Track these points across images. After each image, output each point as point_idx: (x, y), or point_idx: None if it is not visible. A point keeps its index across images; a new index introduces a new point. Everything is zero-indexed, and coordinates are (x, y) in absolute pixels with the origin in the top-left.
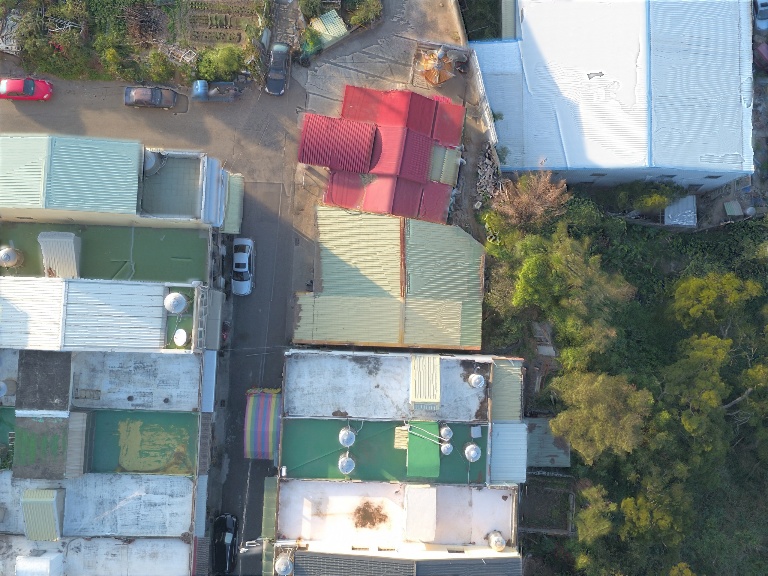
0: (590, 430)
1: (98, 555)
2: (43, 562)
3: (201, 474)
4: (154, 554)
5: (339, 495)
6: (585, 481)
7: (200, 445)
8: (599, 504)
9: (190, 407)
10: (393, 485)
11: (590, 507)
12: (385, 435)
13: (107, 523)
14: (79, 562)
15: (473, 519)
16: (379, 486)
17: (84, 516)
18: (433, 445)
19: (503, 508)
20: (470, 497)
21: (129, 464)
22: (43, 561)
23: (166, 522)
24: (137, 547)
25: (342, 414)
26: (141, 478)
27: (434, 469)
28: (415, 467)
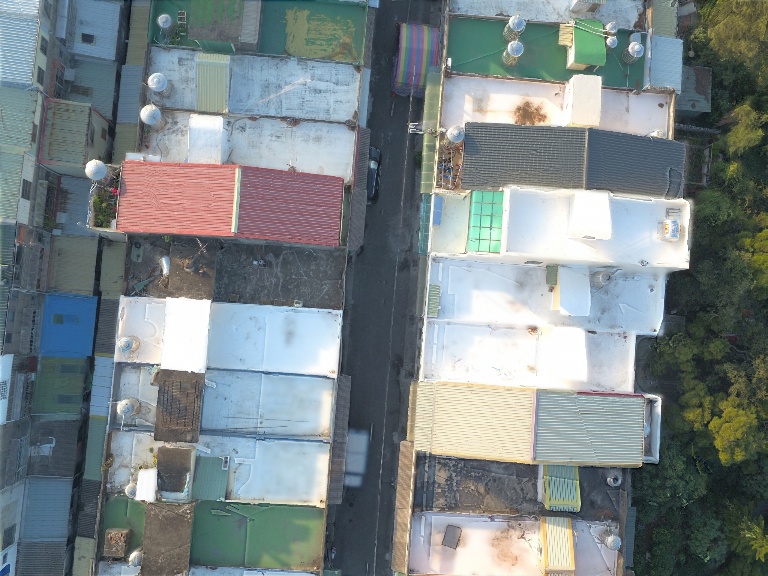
0: (753, 27)
1: (262, 136)
2: (216, 121)
3: (365, 67)
4: (318, 139)
5: (500, 93)
6: (731, 112)
7: (365, 37)
8: (752, 117)
9: (356, 0)
10: (553, 87)
11: (742, 121)
12: (546, 39)
13: (272, 106)
14: (243, 142)
15: (630, 124)
16: (539, 87)
17: (250, 98)
18: (599, 38)
19: (659, 114)
20: (627, 104)
21: (295, 51)
22: (217, 120)
23: (330, 109)
24: (301, 131)
25: (505, 16)
26: (307, 65)
27: (601, 57)
28: (582, 54)
